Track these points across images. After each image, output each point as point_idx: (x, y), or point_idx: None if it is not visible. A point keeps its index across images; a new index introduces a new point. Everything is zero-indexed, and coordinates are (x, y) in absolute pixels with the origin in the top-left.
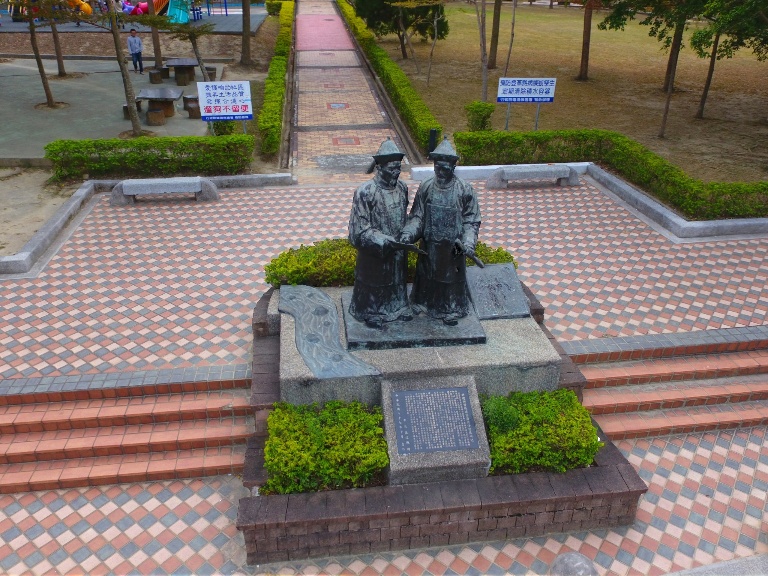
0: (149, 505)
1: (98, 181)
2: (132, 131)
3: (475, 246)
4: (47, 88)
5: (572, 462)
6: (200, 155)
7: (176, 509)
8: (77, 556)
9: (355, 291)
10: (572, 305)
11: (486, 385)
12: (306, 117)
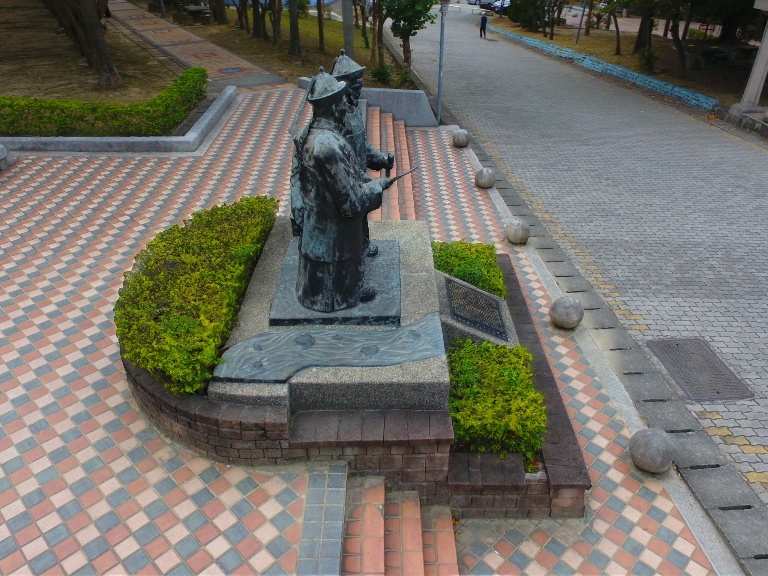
0: None
1: None
2: None
3: None
4: None
5: None
6: None
7: None
8: None
9: (338, 279)
10: None
11: None
12: None
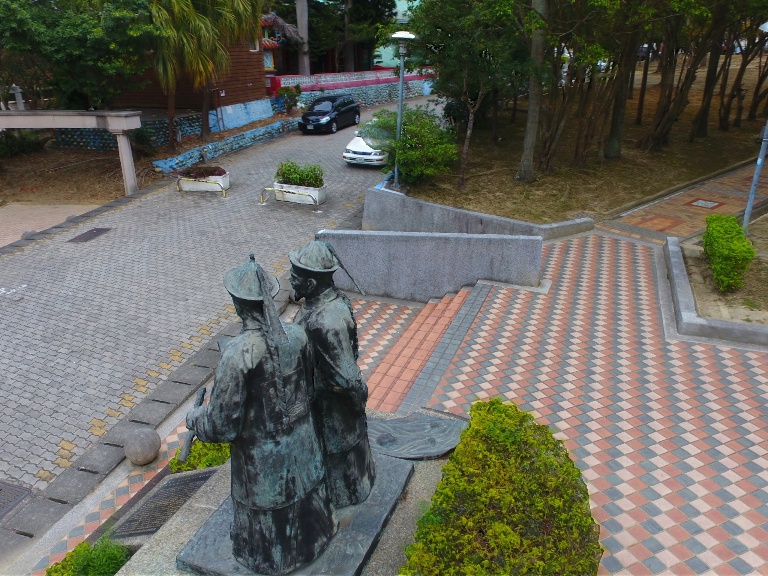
0: None
1: None
2: None
3: None
4: None
5: None
6: None
7: None
8: None
9: None
10: None
11: None
12: None
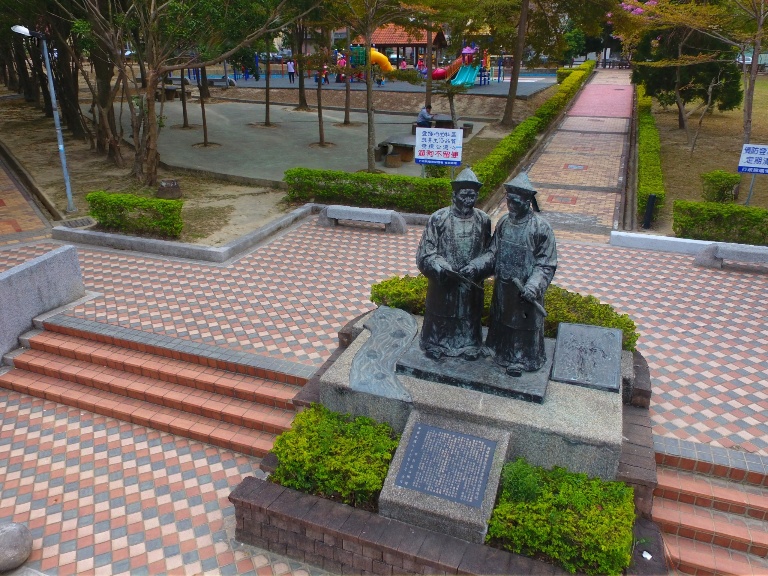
0: (198, 462)
1: (316, 204)
2: (368, 170)
3: (540, 291)
4: (321, 130)
5: (590, 566)
6: (405, 193)
7: (215, 473)
8: (127, 480)
9: (424, 318)
10: (714, 404)
11: (525, 448)
12: (536, 174)
